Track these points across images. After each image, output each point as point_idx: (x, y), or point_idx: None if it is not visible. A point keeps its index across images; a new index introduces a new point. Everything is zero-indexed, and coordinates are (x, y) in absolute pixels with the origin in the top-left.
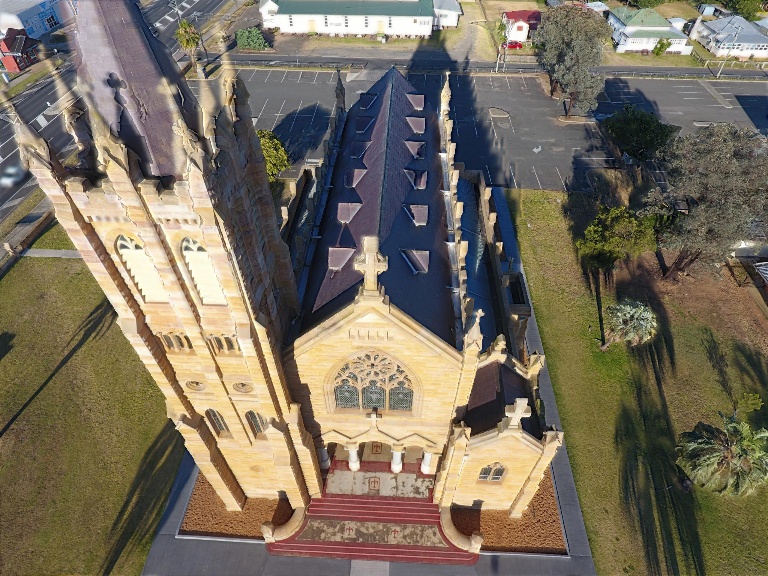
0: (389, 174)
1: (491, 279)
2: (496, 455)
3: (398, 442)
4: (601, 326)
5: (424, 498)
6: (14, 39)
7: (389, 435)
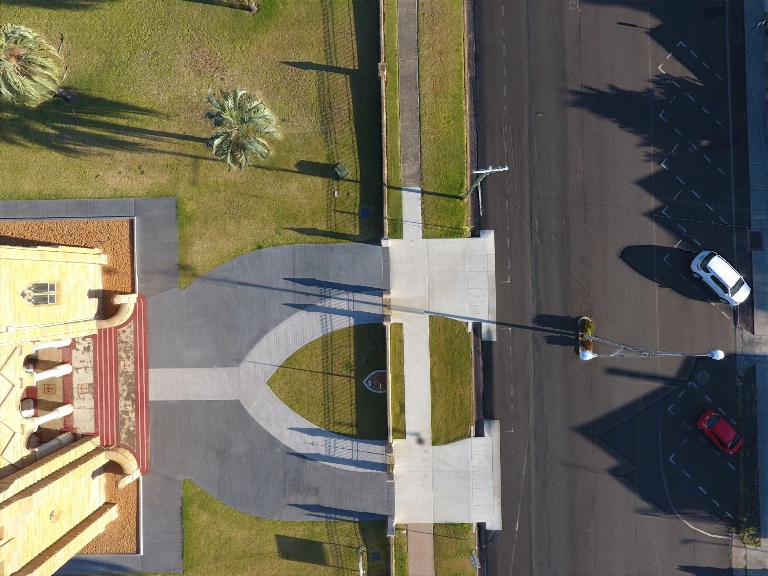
0: None
1: None
2: (6, 301)
3: (17, 385)
4: None
5: (93, 342)
6: None
7: (5, 397)
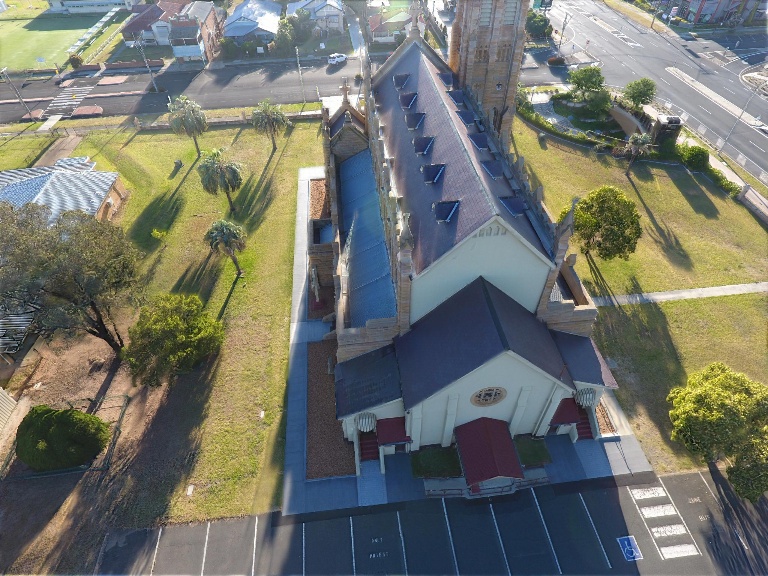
0: None
1: (341, 221)
2: None
3: None
4: (233, 289)
5: None
6: None
7: None
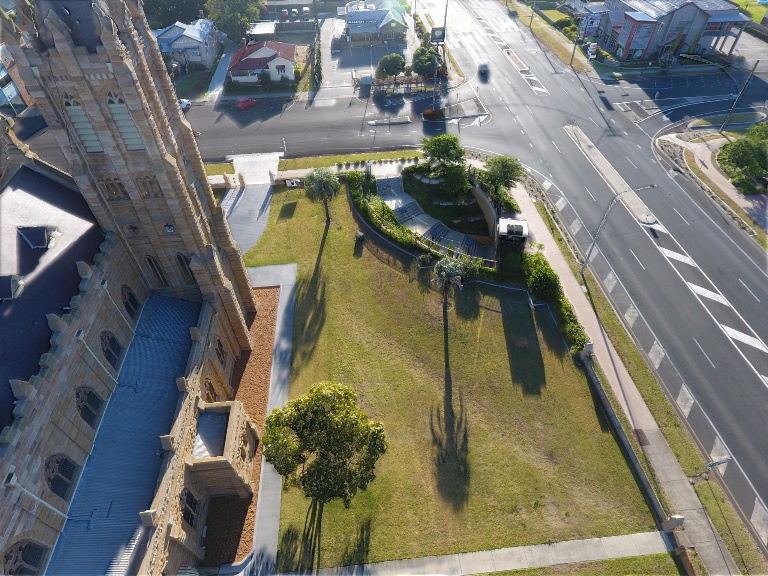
0: None
1: None
2: None
3: None
4: None
5: None
6: None
7: None
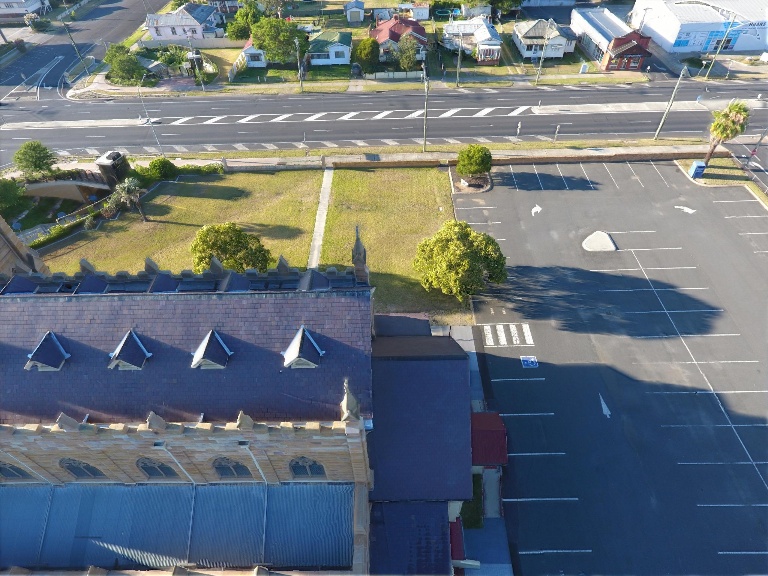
0: (7, 305)
1: None
2: None
3: None
4: None
5: None
6: (628, 42)
7: None
